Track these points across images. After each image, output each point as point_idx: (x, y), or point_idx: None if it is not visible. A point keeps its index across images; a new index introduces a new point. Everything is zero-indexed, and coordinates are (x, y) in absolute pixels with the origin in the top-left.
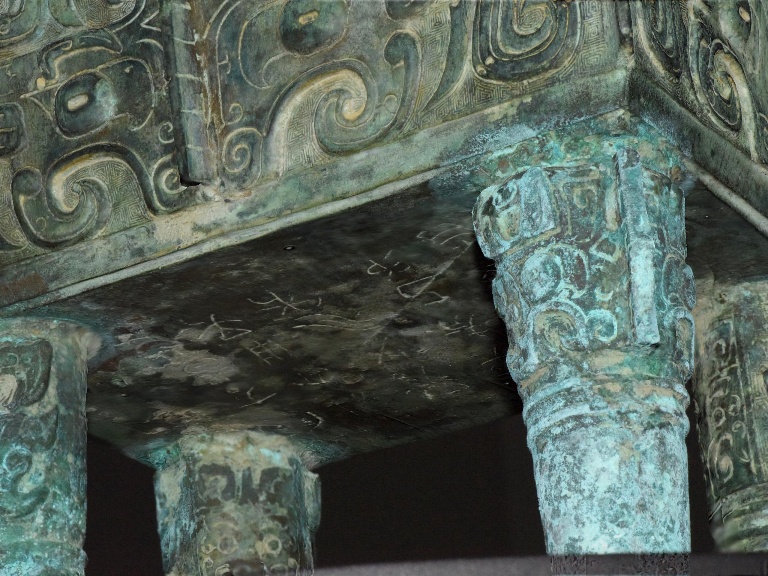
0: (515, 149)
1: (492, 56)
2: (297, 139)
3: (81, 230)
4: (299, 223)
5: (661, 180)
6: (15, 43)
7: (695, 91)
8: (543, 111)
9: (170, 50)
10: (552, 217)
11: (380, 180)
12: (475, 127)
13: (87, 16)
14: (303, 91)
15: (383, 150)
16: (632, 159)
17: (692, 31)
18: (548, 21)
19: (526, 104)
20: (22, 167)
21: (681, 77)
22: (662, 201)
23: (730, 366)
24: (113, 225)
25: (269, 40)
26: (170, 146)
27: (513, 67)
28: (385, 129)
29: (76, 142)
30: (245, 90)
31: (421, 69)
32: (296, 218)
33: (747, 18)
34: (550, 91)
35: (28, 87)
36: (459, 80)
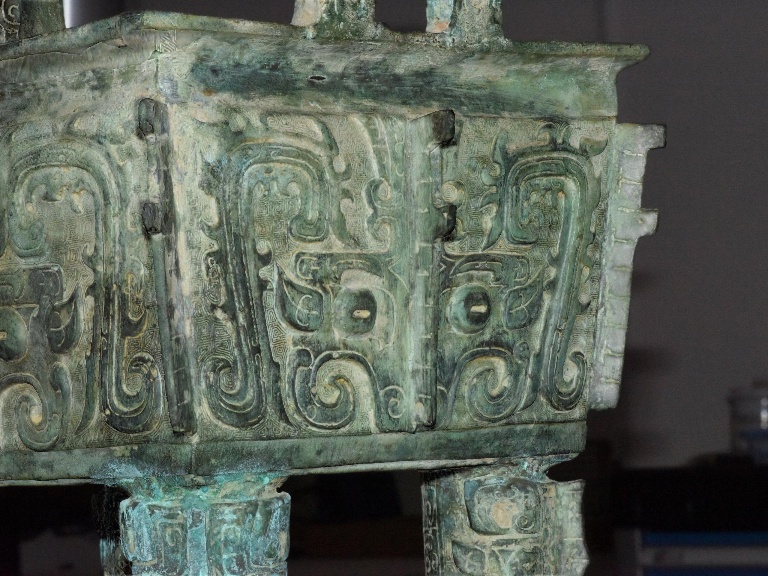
0: (134, 480)
1: (109, 409)
2: (8, 425)
3: None
4: (19, 485)
5: (245, 510)
6: None
7: (288, 418)
8: (145, 460)
9: None
10: (150, 551)
11: (58, 475)
12: (107, 457)
13: None
14: (7, 389)
15: (57, 453)
16: (196, 521)
17: (289, 361)
18: (143, 389)
19: (135, 451)
20: None
21: (269, 414)
22: (245, 528)
23: (433, 527)
24: None
25: None
26: None
27: (121, 423)
28: (53, 441)
29: None
30: None
31: (72, 399)
32: (17, 482)
33: (367, 313)
34: (148, 446)
35: None
36: (93, 418)
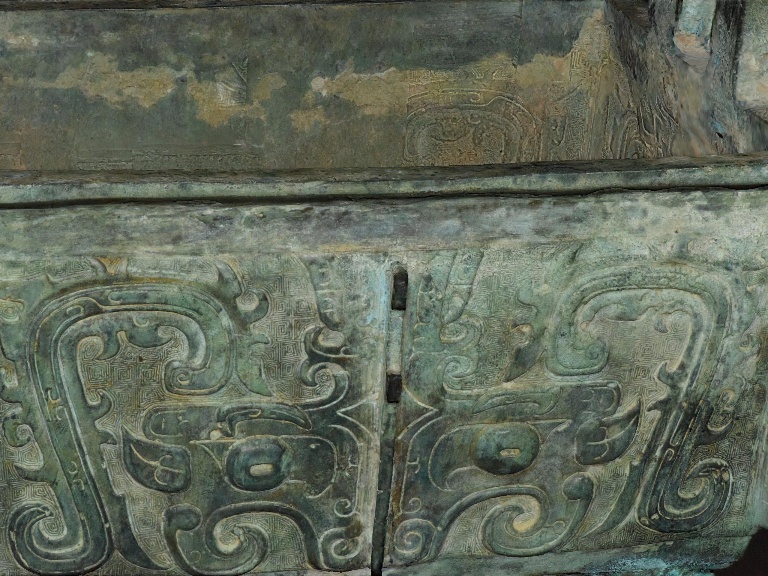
0: (643, 570)
1: (659, 514)
2: (464, 533)
3: (237, 568)
4: None
5: None
6: (195, 395)
7: None
8: (679, 553)
9: (389, 469)
10: None
11: (526, 574)
12: (621, 554)
13: (277, 387)
14: None
15: None
16: None
17: None
18: (706, 492)
19: (668, 546)
20: (181, 503)
21: None
22: None
23: None
24: (268, 567)
25: (462, 454)
26: (346, 520)
27: (673, 526)
28: (550, 547)
29: (247, 496)
30: (428, 489)
31: (591, 505)
32: None
33: None
34: (690, 541)
35: (200, 436)
36: (622, 522)
